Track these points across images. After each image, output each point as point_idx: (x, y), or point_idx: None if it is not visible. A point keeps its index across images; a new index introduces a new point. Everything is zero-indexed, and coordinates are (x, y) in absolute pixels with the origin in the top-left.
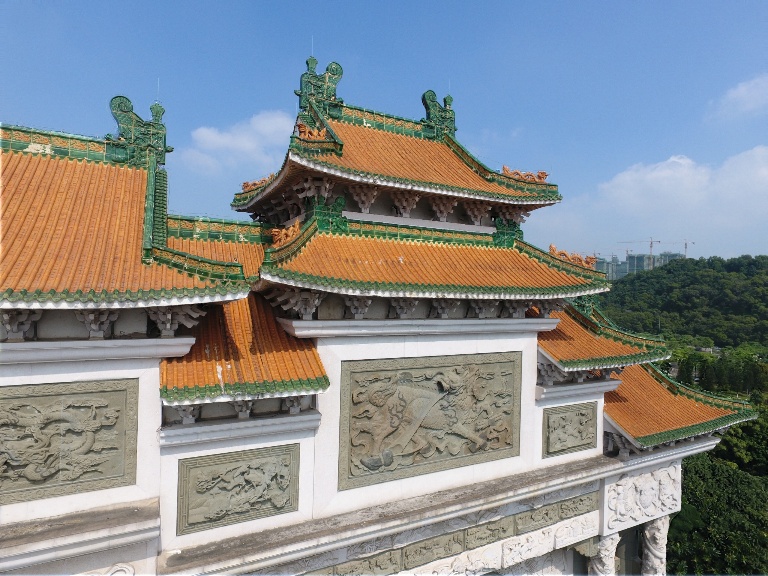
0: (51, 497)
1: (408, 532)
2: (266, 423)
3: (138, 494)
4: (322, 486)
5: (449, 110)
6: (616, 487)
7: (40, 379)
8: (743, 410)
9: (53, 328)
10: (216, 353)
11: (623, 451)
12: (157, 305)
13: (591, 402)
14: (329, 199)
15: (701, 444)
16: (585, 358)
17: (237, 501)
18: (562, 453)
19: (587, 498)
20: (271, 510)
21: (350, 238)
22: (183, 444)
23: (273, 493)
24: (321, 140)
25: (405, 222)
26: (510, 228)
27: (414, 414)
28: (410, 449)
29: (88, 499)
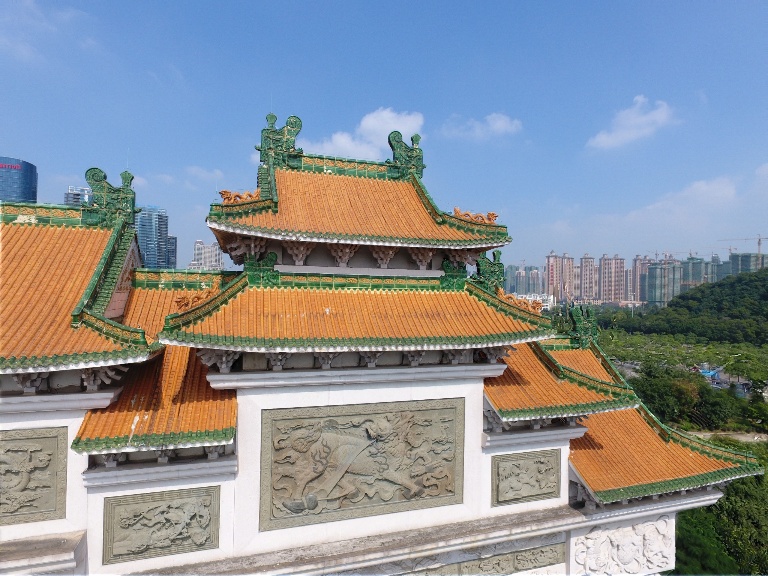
0: None
1: (334, 574)
2: (181, 468)
3: (67, 527)
4: (242, 526)
5: (416, 149)
6: (585, 540)
7: None
8: (746, 464)
9: (0, 383)
10: (141, 403)
11: (588, 503)
12: (67, 369)
13: (553, 449)
14: (262, 254)
15: (695, 498)
16: (532, 406)
17: (157, 537)
18: (516, 502)
19: (550, 550)
20: (192, 546)
21: (281, 290)
22: (105, 485)
23: (194, 531)
24: (253, 200)
25: (341, 271)
26: (460, 270)
27: (340, 460)
28: (336, 494)
29: (24, 529)
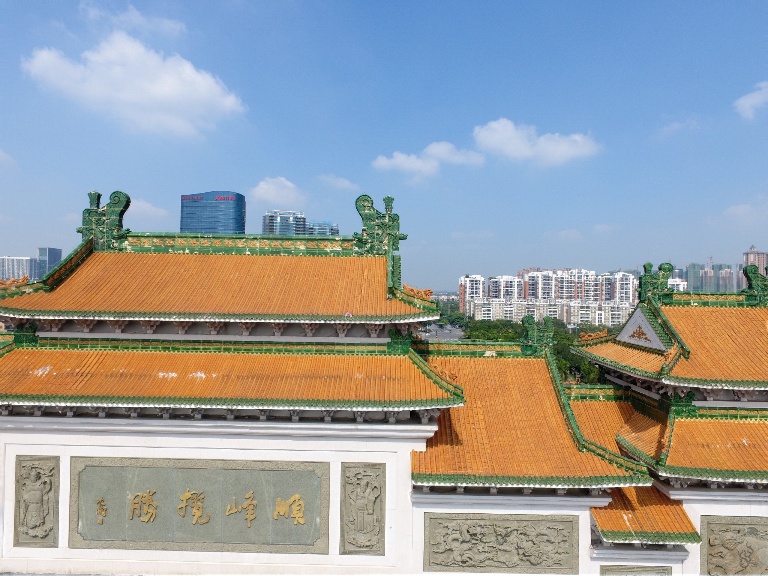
0: (540, 574)
1: None
2: (653, 553)
3: None
4: None
5: None
6: None
7: (535, 512)
8: None
9: None
10: (618, 503)
11: None
12: (601, 487)
13: None
14: None
15: None
16: None
17: None
18: None
19: None
20: None
21: (699, 421)
22: None
23: None
24: (675, 353)
25: (743, 405)
26: None
27: (760, 560)
28: None
29: None
